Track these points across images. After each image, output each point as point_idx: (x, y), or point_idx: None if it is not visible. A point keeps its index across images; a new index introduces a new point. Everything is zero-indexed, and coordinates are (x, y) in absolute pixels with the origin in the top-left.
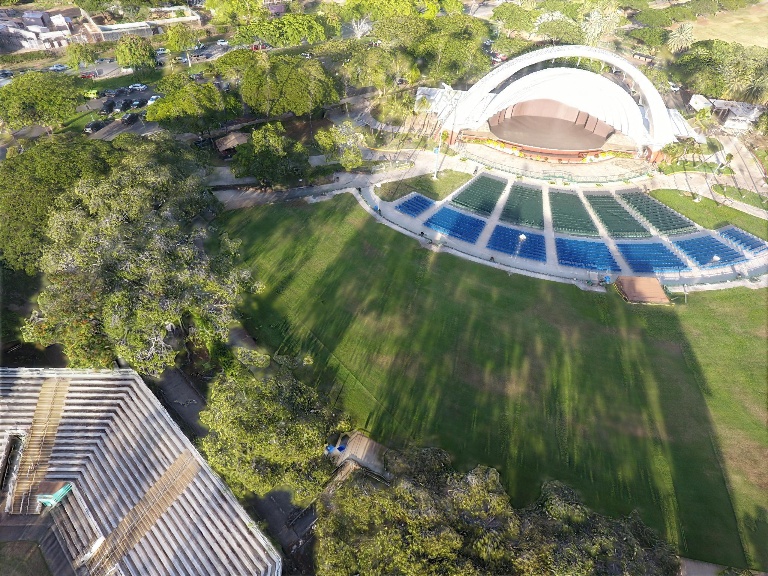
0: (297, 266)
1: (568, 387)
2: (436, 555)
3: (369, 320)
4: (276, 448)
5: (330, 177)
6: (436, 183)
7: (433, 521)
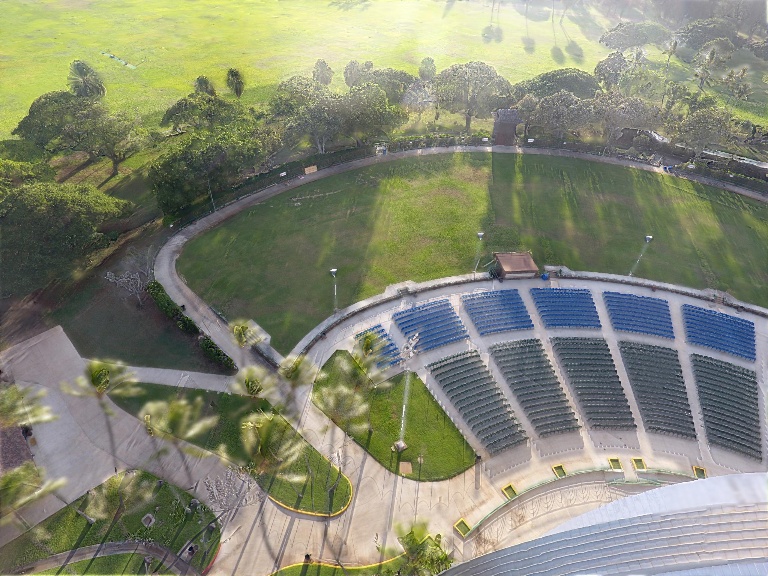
0: None
1: (567, 199)
2: None
3: (708, 221)
4: None
5: None
6: None
7: None
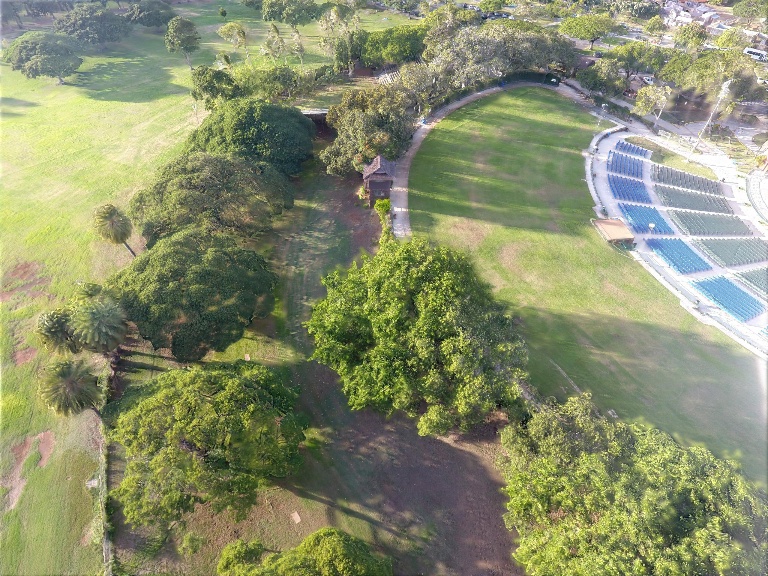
0: (525, 111)
1: None
2: (379, 92)
3: (500, 130)
4: (404, 74)
5: (626, 116)
6: (680, 162)
7: (387, 86)
